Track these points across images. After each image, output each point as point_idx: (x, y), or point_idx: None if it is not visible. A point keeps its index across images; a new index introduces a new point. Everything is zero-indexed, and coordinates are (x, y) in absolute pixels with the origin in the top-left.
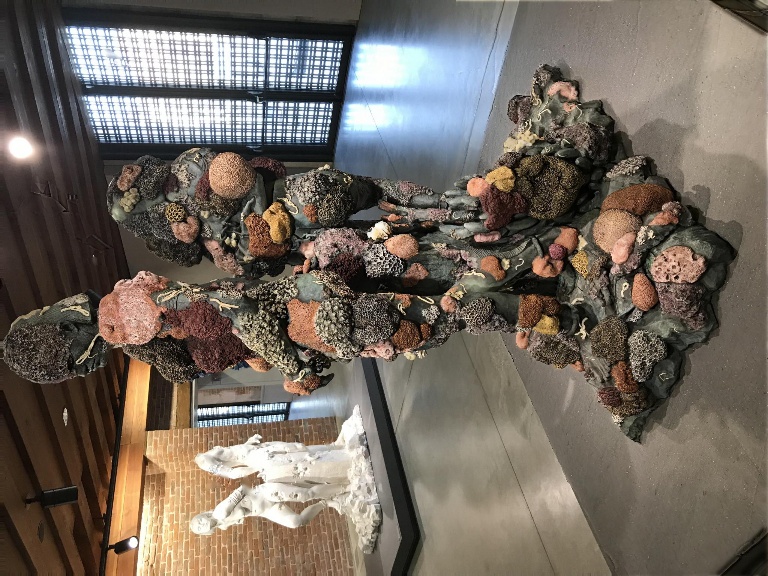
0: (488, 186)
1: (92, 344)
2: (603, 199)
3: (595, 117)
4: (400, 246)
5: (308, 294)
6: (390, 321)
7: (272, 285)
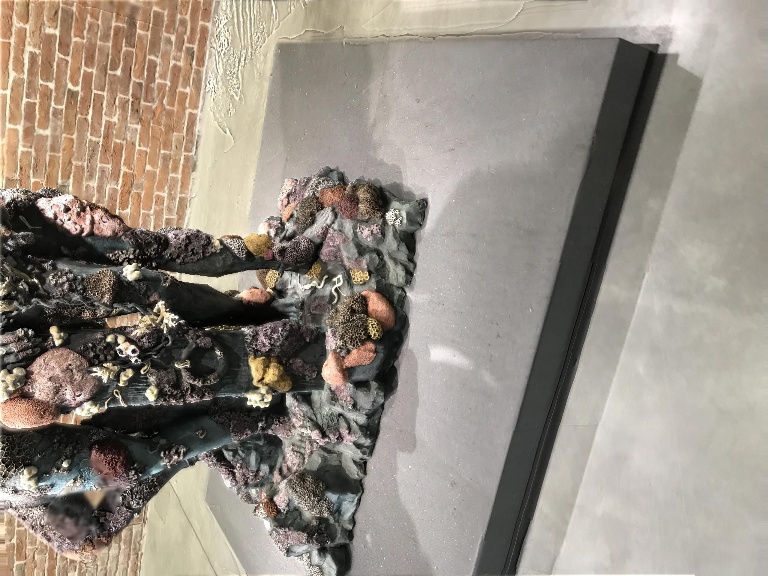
0: None
1: None
2: None
3: None
4: None
5: None
6: None
7: None
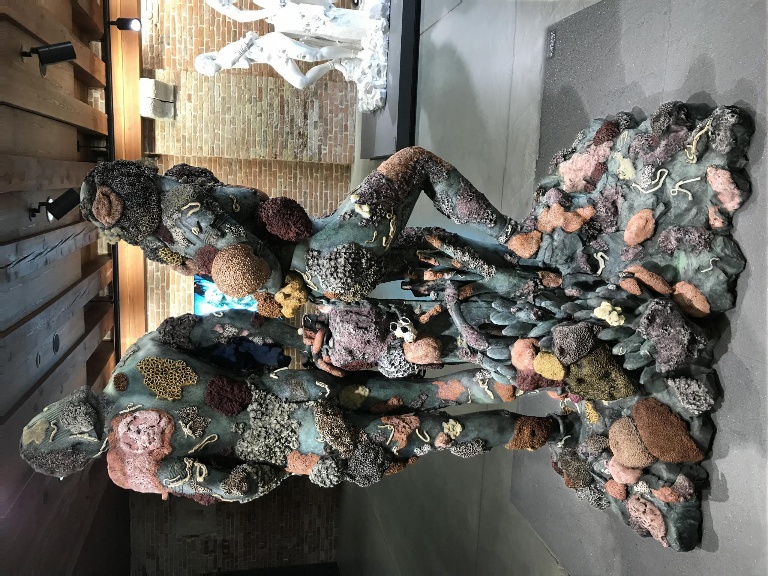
0: (532, 371)
1: (104, 446)
2: (651, 386)
3: (718, 292)
4: (419, 360)
5: (308, 448)
6: (380, 472)
7: (274, 442)
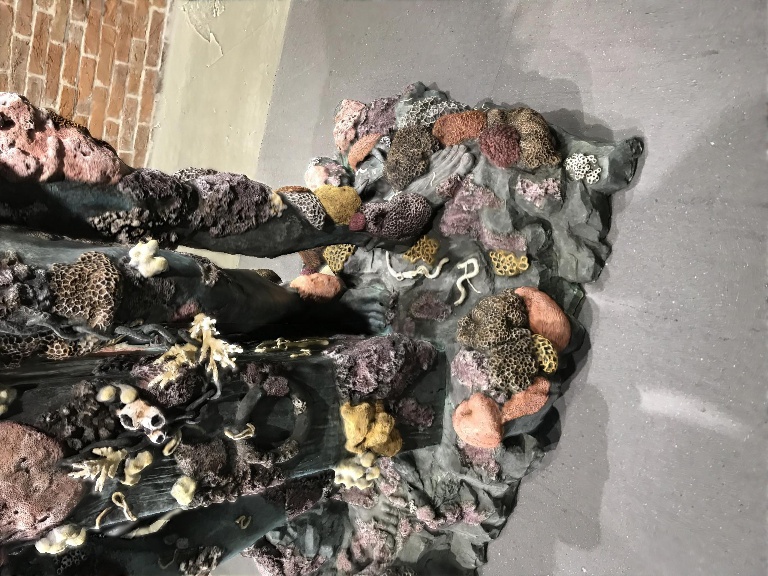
0: None
1: None
2: None
3: None
4: None
5: None
6: None
7: None
